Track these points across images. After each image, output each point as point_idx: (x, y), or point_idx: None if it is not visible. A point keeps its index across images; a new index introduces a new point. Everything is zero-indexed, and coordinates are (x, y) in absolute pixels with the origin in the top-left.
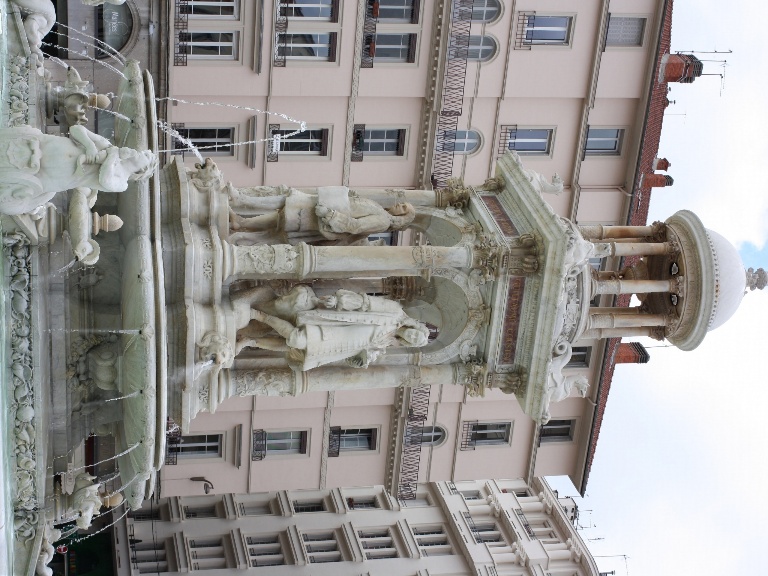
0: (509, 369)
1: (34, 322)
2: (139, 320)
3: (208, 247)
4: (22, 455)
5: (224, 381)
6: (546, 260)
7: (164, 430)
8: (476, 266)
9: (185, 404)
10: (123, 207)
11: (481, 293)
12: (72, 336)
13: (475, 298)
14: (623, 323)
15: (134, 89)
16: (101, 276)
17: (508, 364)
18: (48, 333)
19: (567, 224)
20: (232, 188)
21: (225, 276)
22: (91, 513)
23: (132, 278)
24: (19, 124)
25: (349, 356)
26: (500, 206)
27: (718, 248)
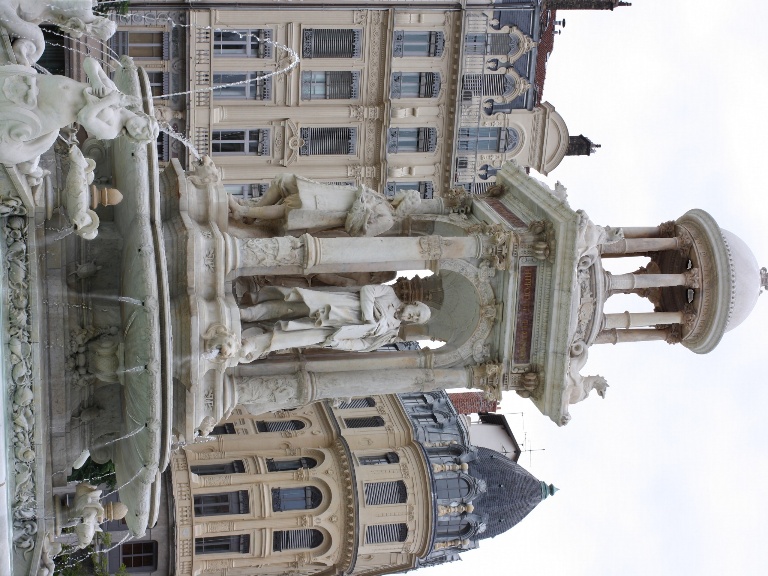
0: None
1: None
2: None
3: None
4: None
5: None
6: (503, 177)
7: (147, 77)
8: (447, 201)
9: None
10: None
11: None
12: None
13: None
14: None
15: None
16: None
17: None
18: None
19: None
20: None
21: None
22: (86, 181)
23: None
24: None
25: (345, 199)
26: None
27: None
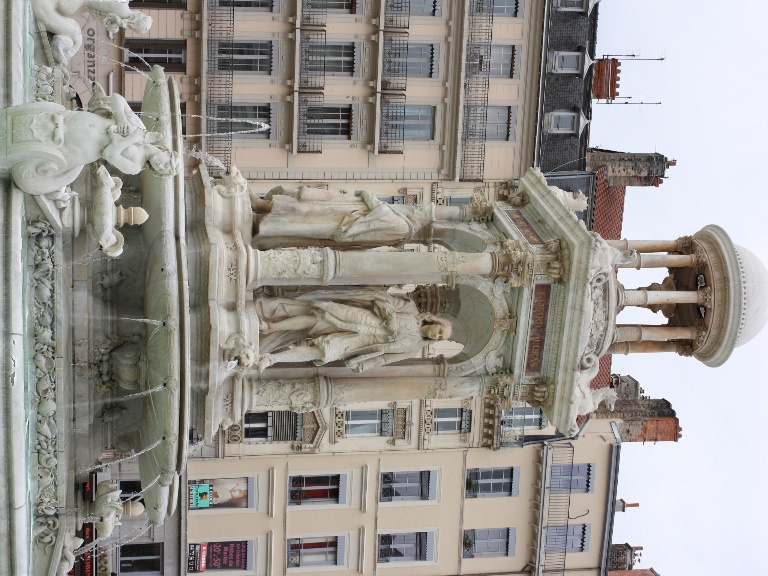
0: None
1: None
2: (152, 518)
3: (228, 411)
4: None
5: None
6: None
7: None
8: None
9: None
10: None
11: None
12: None
13: None
14: None
15: (167, 449)
16: None
17: None
18: None
19: (605, 324)
20: (263, 368)
21: None
22: None
23: (150, 491)
24: (48, 493)
25: None
26: (547, 308)
27: (743, 338)
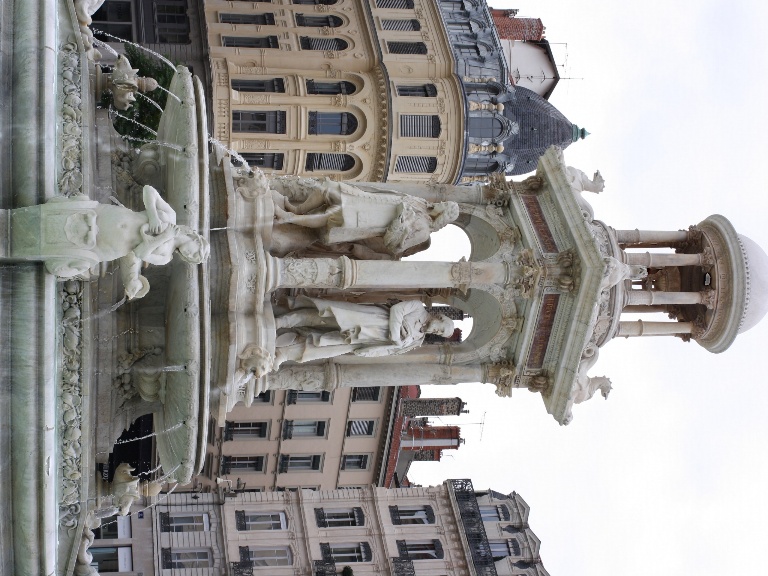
0: None
1: (83, 52)
2: None
3: None
4: None
5: None
6: (544, 168)
7: (204, 109)
8: (486, 192)
9: (232, 243)
10: None
11: None
12: (116, 147)
13: (500, 226)
14: (658, 255)
15: None
16: None
17: (554, 253)
18: None
19: None
20: None
21: None
22: None
23: None
24: None
25: (386, 214)
26: None
27: None
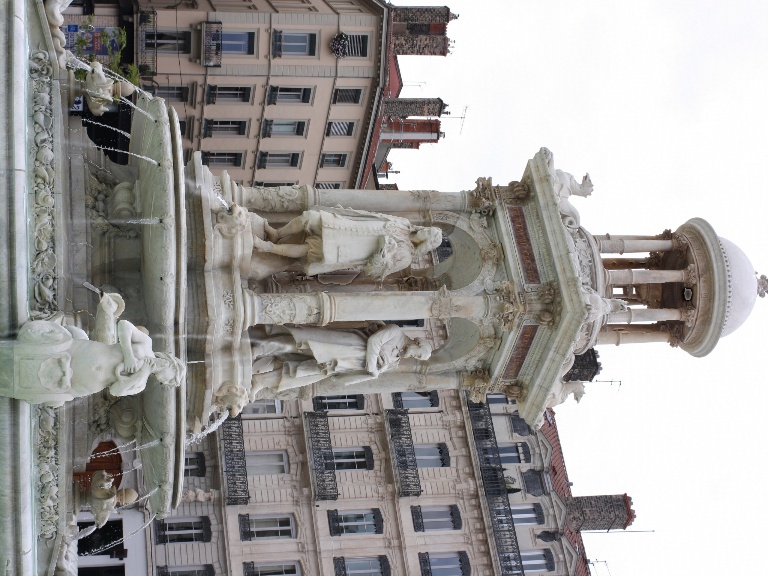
0: (538, 289)
1: (54, 82)
2: None
3: None
4: (41, 190)
5: (248, 294)
6: (532, 176)
7: (182, 167)
8: (472, 200)
9: (209, 290)
10: (135, 142)
11: (487, 235)
12: (91, 180)
13: (483, 241)
14: (641, 273)
15: None
16: (117, 180)
17: (535, 284)
18: (68, 159)
19: None
20: None
21: (235, 196)
22: (114, 329)
23: None
24: None
25: (367, 247)
26: None
27: None
